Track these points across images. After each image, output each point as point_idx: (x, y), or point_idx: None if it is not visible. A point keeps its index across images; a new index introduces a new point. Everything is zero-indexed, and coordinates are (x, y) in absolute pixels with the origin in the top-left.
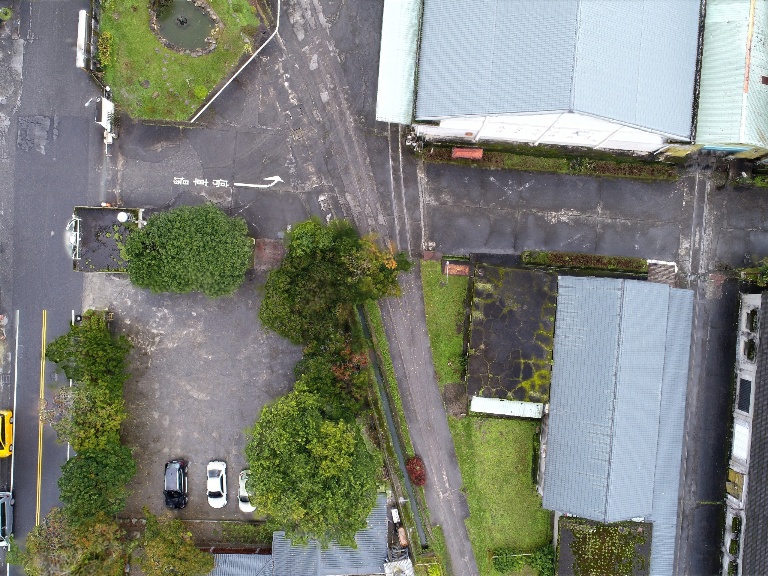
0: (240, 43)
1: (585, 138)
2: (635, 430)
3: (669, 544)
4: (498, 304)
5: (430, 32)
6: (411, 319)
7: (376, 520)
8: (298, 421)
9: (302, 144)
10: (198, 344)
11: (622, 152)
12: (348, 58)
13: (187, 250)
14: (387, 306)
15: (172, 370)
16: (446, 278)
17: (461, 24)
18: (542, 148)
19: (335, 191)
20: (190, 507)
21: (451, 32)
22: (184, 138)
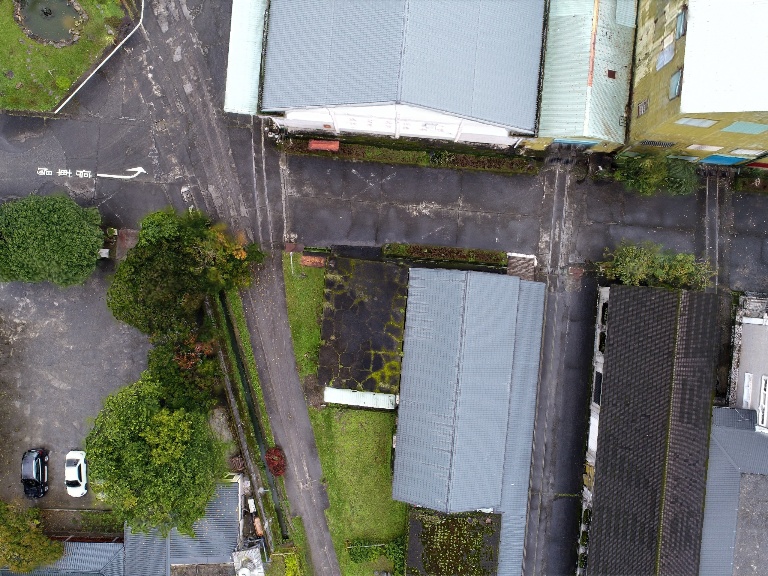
0: (104, 34)
1: (439, 131)
2: (481, 421)
3: (519, 535)
4: (349, 295)
5: (275, 24)
6: (272, 310)
7: (227, 509)
8: (133, 409)
9: (165, 135)
10: (60, 334)
11: (483, 145)
12: (211, 50)
13: (31, 239)
14: (249, 297)
15: (34, 360)
16: (307, 270)
17: (303, 16)
18: (403, 141)
19: (198, 182)
20: (50, 496)
21: (294, 24)
22: (48, 129)
